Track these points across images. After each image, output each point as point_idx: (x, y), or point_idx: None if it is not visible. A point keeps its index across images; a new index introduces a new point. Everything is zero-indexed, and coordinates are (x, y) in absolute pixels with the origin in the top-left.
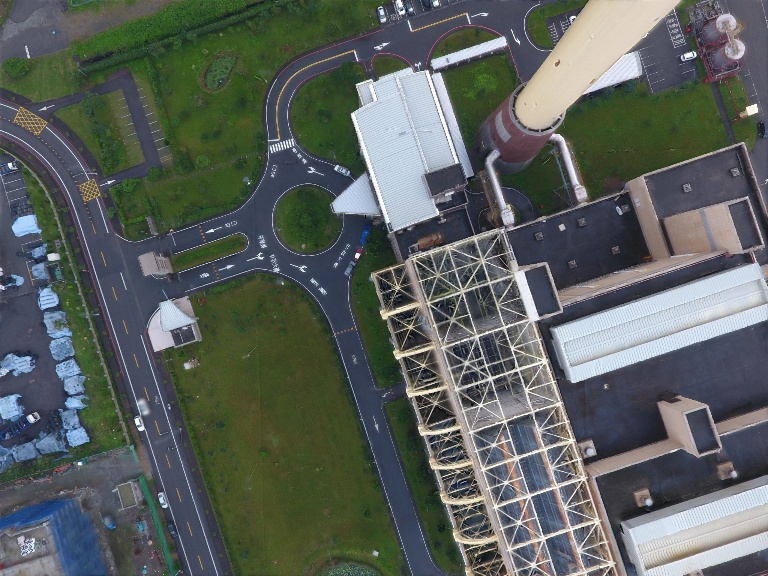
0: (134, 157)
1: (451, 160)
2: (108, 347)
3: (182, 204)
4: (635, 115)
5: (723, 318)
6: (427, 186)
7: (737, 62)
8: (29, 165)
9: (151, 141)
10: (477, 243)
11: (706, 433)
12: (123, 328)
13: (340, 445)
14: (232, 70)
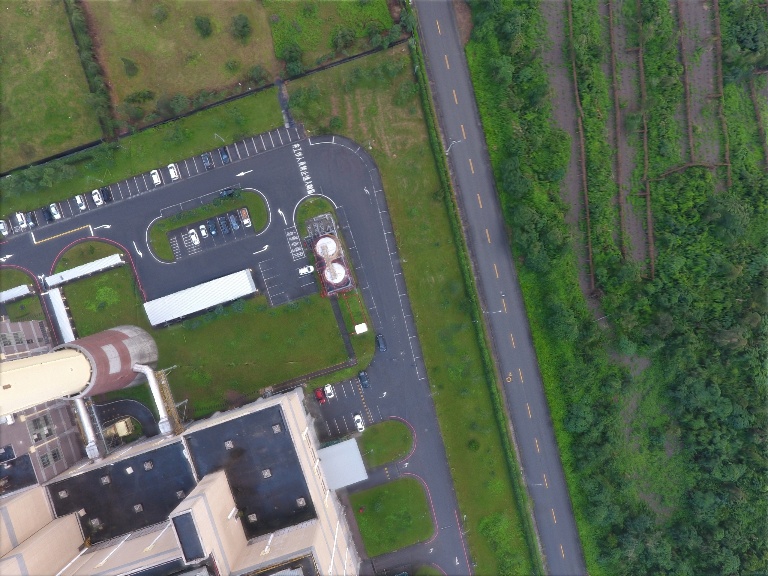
0: None
1: None
2: None
3: None
4: (255, 328)
5: None
6: None
7: (349, 279)
8: None
9: None
10: None
11: None
12: None
13: None
14: None
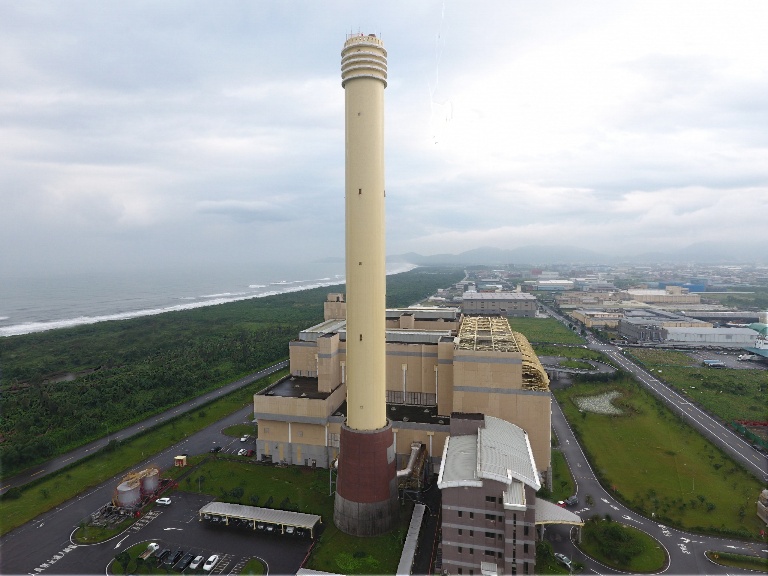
0: None
1: None
2: None
3: None
4: (246, 492)
5: None
6: None
7: None
8: None
9: None
10: None
11: None
12: None
13: (600, 442)
14: None
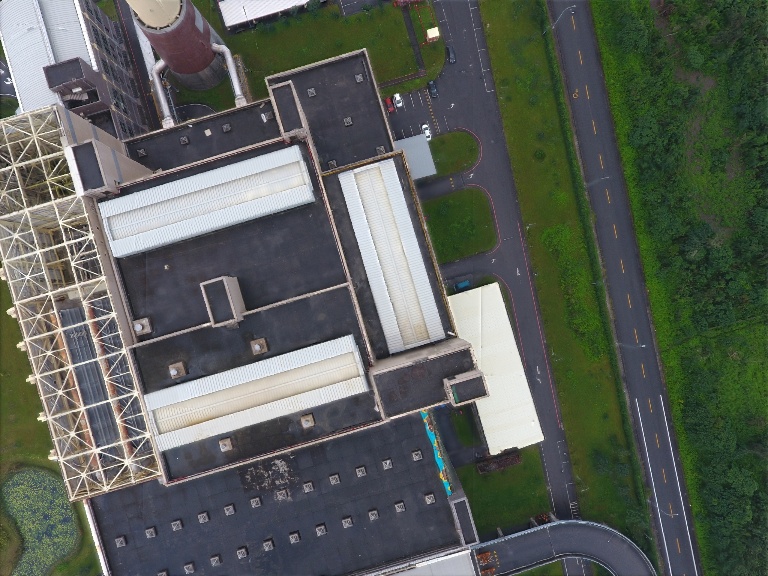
0: None
1: (87, 59)
2: None
3: None
4: (326, 36)
5: (260, 198)
6: (46, 79)
7: None
8: None
9: None
10: (30, 119)
11: (225, 305)
12: None
13: None
14: None
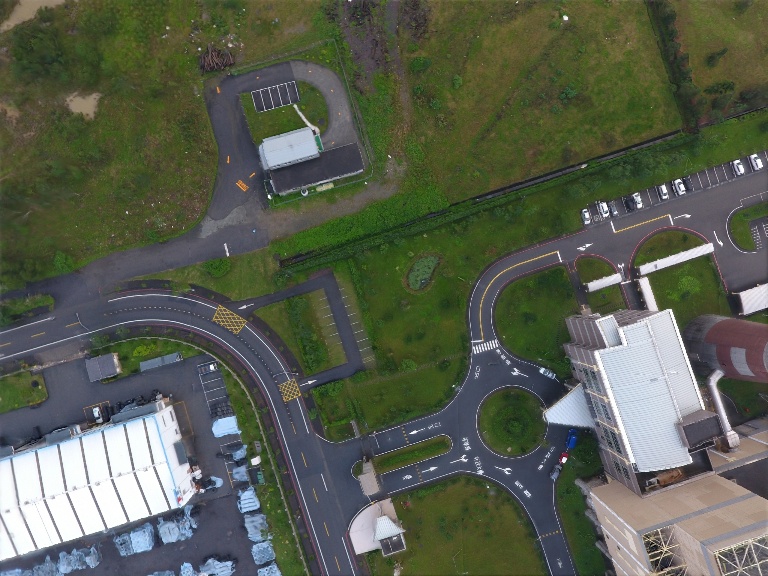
0: (336, 357)
1: (696, 400)
2: (309, 550)
3: (385, 406)
4: None
5: None
6: (684, 437)
7: None
8: (228, 365)
9: (353, 341)
10: None
11: None
12: (324, 530)
13: None
14: (435, 270)
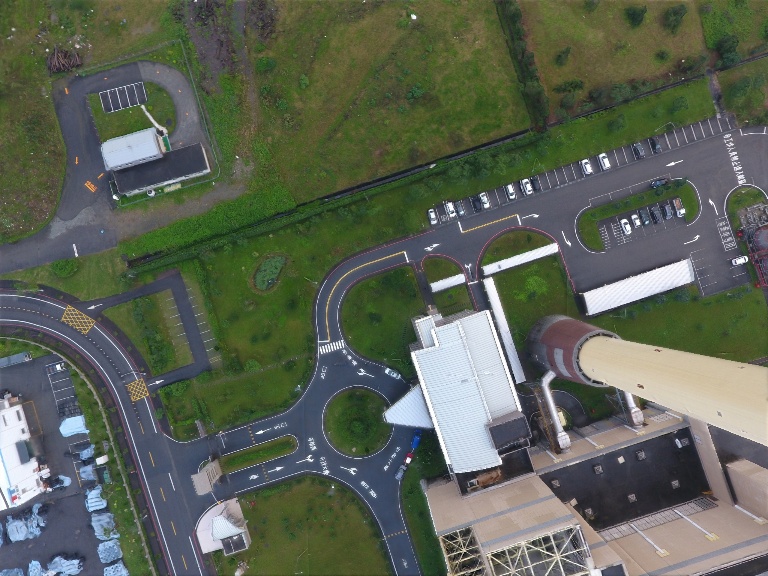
0: (183, 357)
1: (512, 401)
2: (156, 549)
3: (231, 406)
4: (686, 318)
5: None
6: (491, 439)
7: None
8: (77, 364)
9: (200, 342)
10: (552, 539)
11: None
12: (171, 529)
13: None
14: (282, 271)
